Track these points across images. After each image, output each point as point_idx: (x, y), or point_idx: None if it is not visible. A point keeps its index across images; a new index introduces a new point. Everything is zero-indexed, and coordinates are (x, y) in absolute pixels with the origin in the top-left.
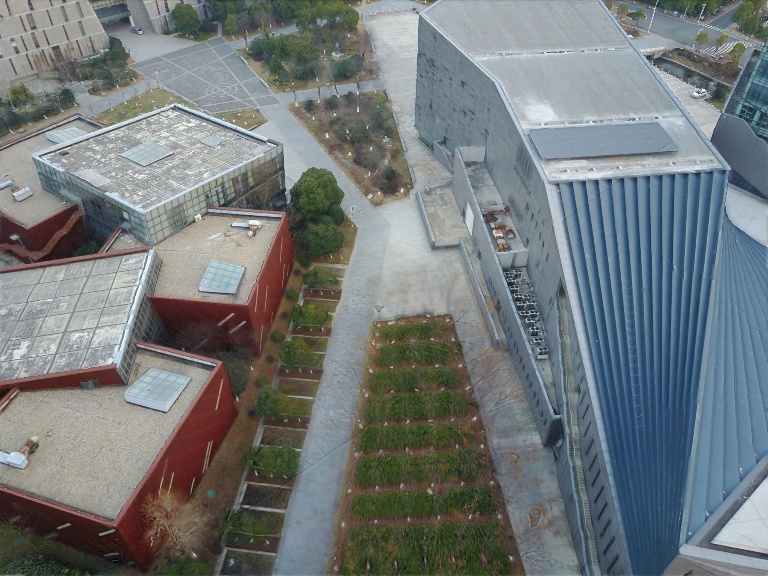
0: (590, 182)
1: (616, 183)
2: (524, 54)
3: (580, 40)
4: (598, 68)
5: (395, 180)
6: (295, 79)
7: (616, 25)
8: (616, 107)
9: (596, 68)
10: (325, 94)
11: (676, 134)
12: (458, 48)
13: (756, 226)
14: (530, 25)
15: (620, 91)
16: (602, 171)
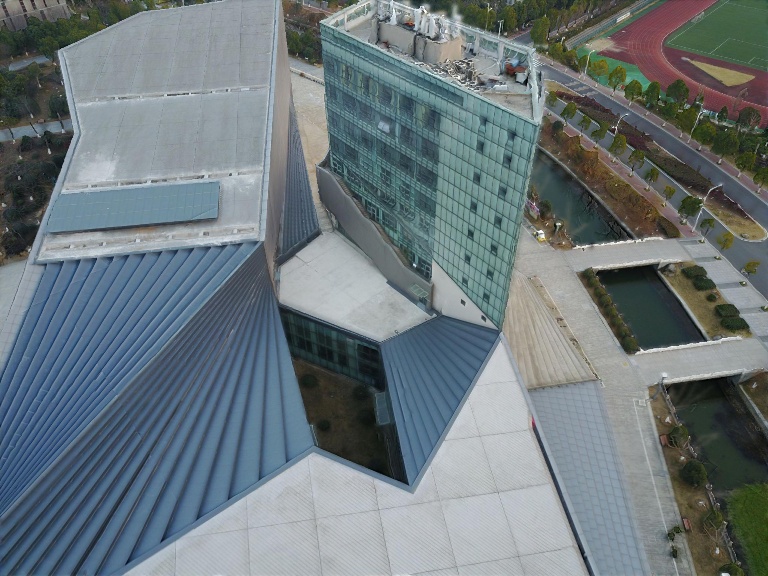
0: (86, 261)
1: (118, 261)
2: (139, 98)
3: (216, 79)
4: (210, 113)
5: (27, 237)
6: (6, 116)
7: (272, 60)
8: (192, 162)
9: (208, 113)
10: (31, 132)
11: (235, 195)
12: (67, 92)
13: (344, 296)
14: (174, 62)
15: (212, 142)
16: (111, 246)
